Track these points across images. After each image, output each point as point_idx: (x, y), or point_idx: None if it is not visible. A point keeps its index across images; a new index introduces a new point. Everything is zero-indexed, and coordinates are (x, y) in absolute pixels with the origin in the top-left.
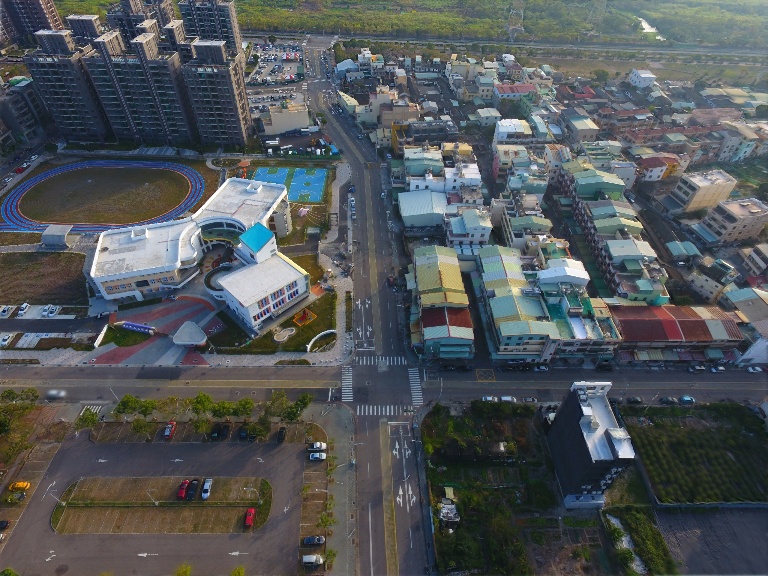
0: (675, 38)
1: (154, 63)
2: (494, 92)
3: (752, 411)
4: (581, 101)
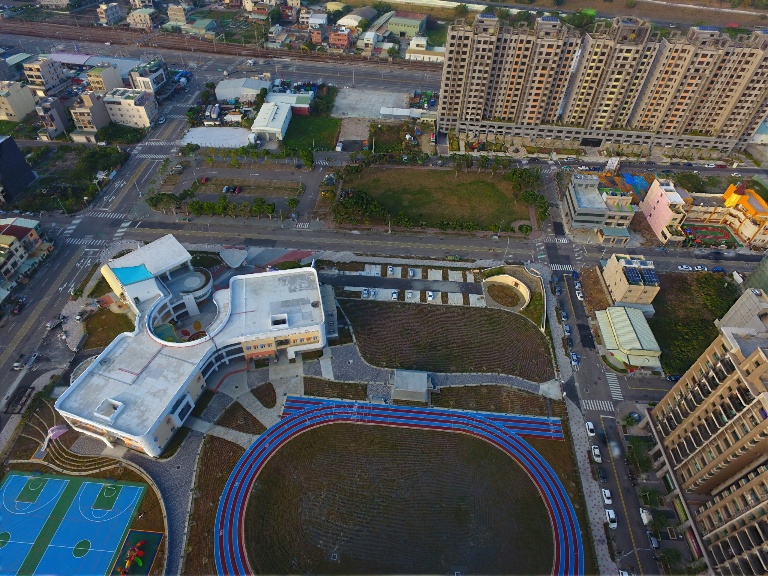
0: None
1: None
2: None
3: None
4: None
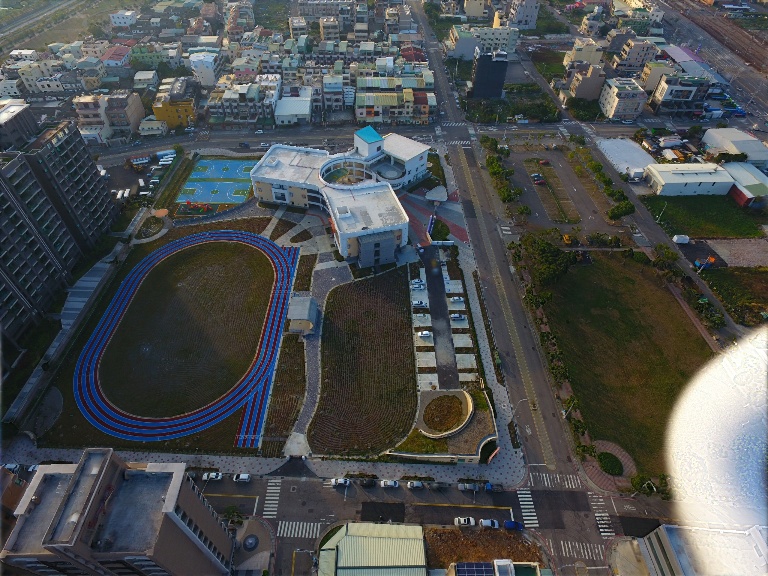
0: (18, 3)
1: (9, 170)
2: (108, 66)
3: (449, 59)
4: None
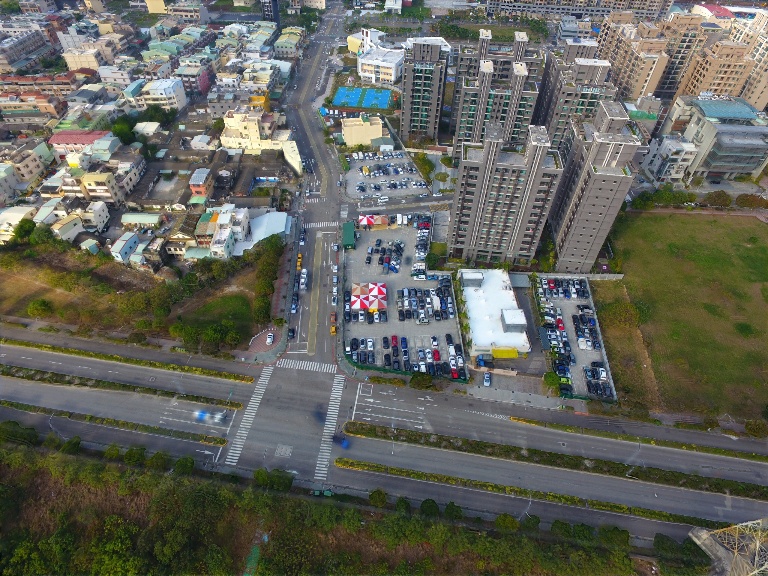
0: None
1: None
2: None
3: None
4: (4, 146)
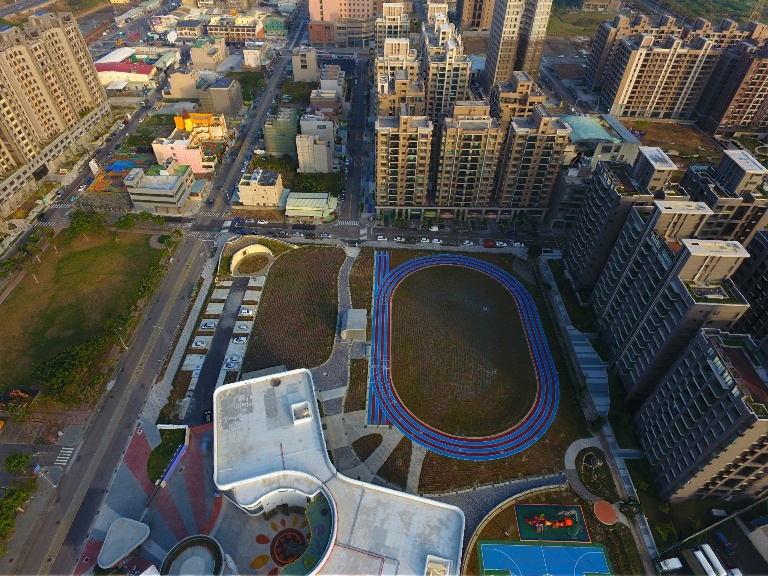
0: None
1: (680, 287)
2: None
3: None
4: None
